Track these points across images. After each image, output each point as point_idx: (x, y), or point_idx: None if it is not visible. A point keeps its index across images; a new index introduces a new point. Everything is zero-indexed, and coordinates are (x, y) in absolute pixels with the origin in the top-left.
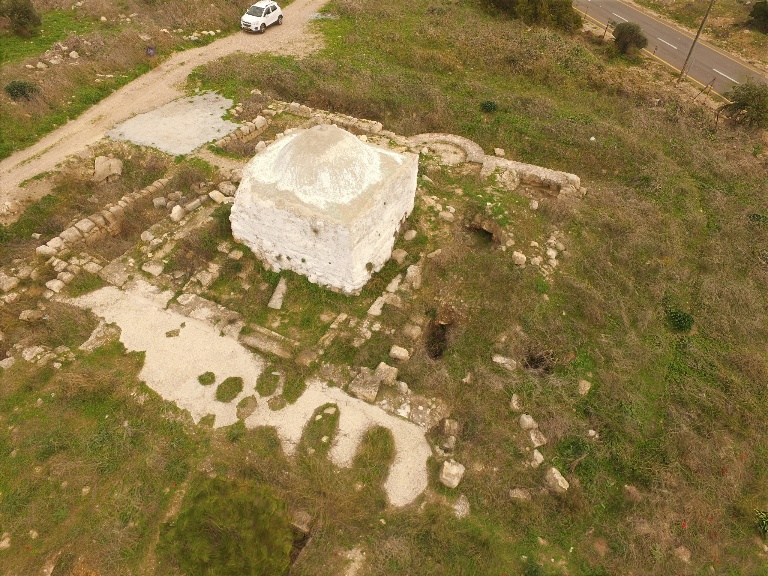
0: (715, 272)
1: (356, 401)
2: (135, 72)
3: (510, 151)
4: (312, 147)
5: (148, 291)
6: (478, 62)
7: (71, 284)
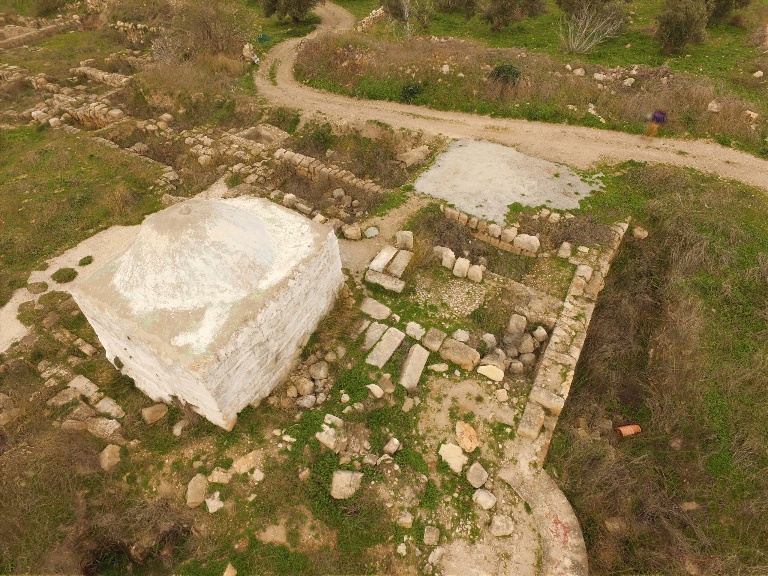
0: None
1: None
2: (620, 125)
3: None
4: None
5: None
6: None
7: None
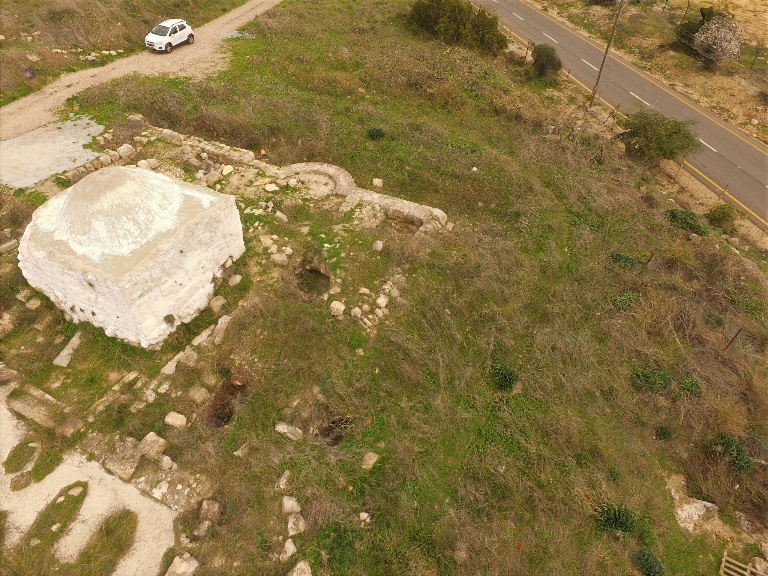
0: (556, 321)
1: (111, 479)
2: (13, 95)
3: (389, 181)
4: (86, 193)
5: None
6: (383, 85)
7: None
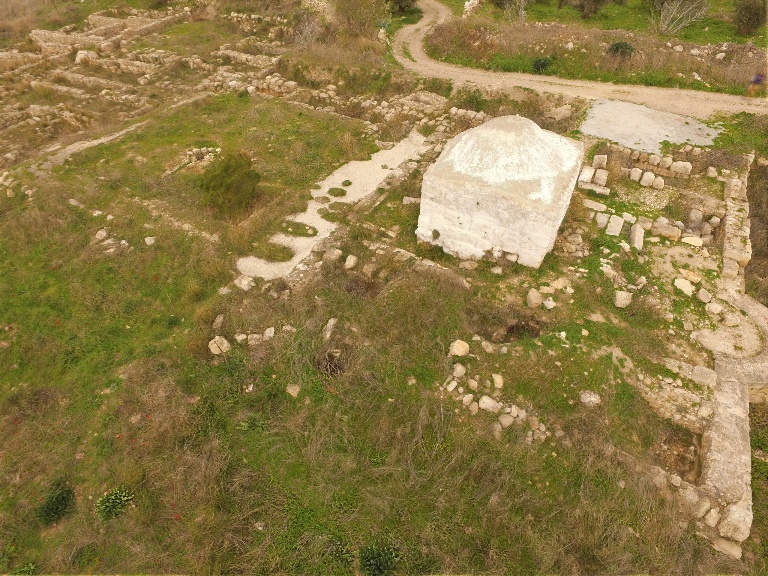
0: None
1: None
2: (723, 88)
3: None
4: (492, 121)
5: (420, 150)
6: None
7: (426, 126)
